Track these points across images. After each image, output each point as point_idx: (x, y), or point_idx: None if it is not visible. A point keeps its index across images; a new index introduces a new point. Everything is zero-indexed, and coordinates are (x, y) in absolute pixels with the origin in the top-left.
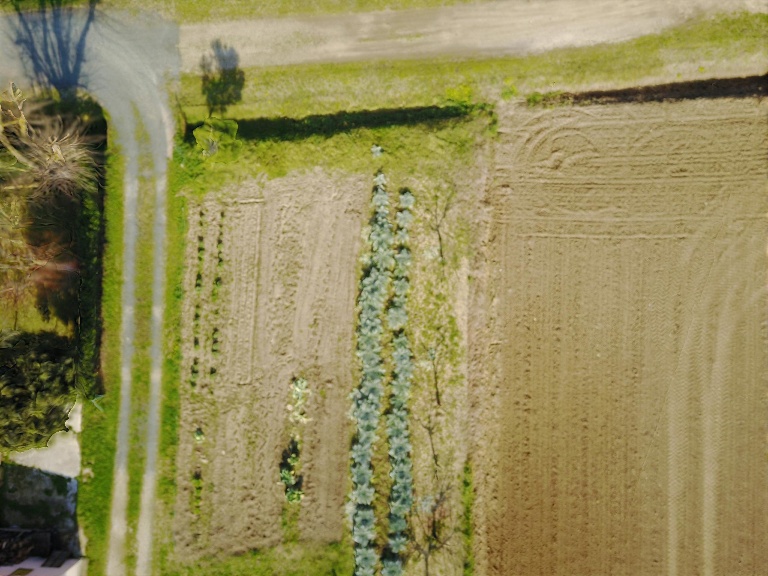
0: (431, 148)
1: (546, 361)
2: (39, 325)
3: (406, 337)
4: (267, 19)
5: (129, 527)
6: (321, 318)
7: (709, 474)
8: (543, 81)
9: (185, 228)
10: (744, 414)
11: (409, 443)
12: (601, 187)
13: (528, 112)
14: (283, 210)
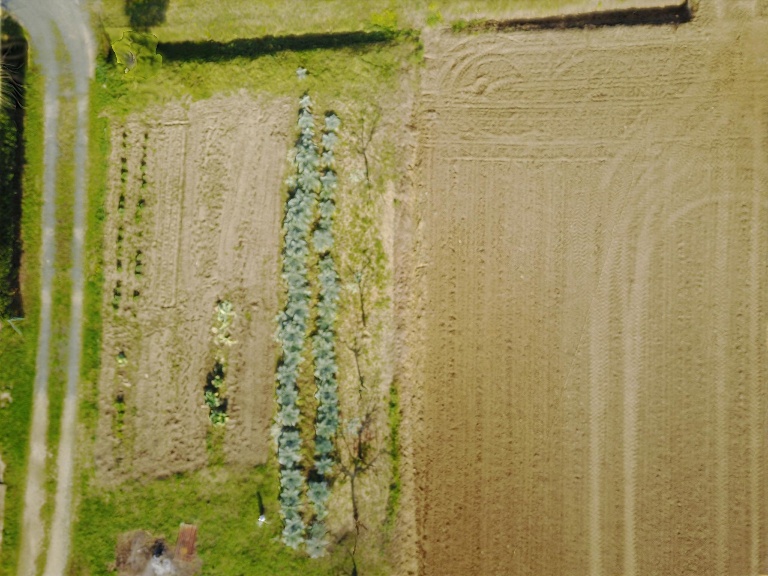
0: (357, 71)
1: (471, 283)
2: None
3: (332, 259)
4: None
5: (48, 452)
6: (246, 240)
7: (628, 391)
8: (468, 7)
9: (108, 149)
10: (661, 331)
11: (334, 364)
12: (524, 111)
13: (454, 38)
14: (208, 132)
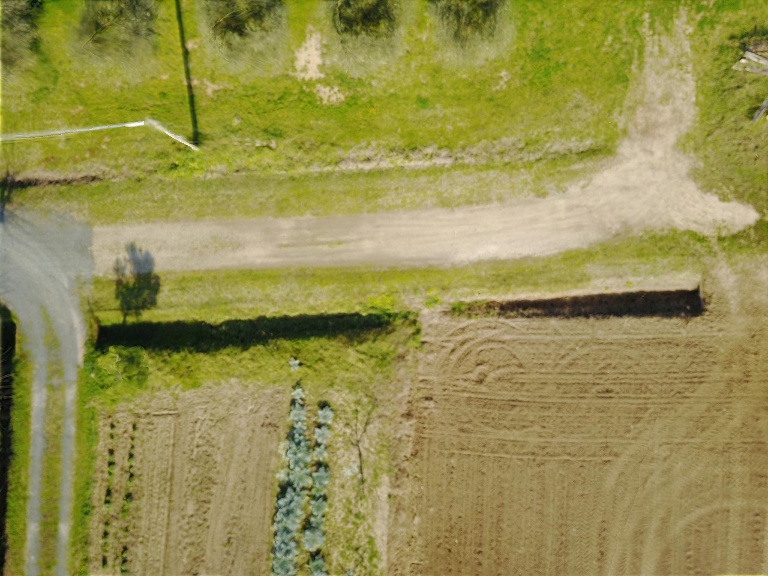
0: (351, 361)
1: None
2: None
3: (323, 559)
4: (184, 222)
5: None
6: (235, 537)
7: None
8: (468, 292)
9: (95, 441)
10: None
11: None
12: (526, 405)
13: (453, 322)
14: (197, 423)
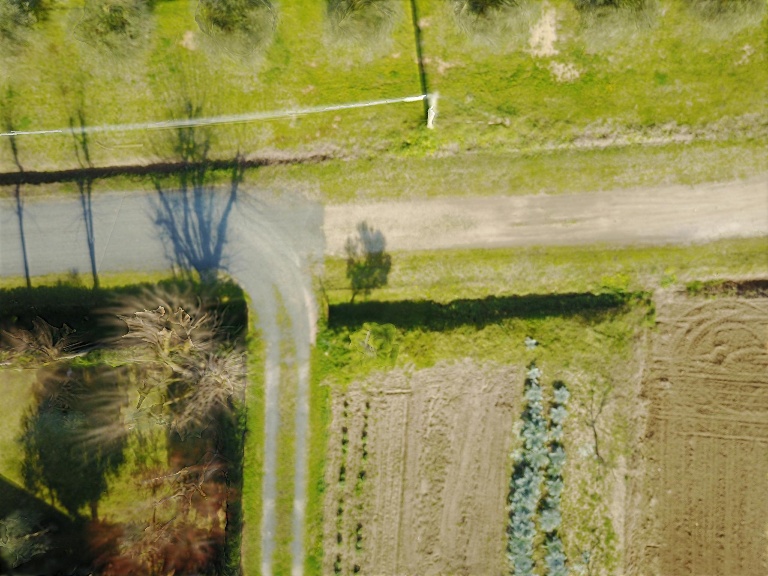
0: (588, 341)
1: (709, 569)
2: (178, 517)
3: (560, 540)
4: (415, 201)
5: None
6: (470, 516)
7: None
8: (706, 271)
9: (329, 419)
10: None
11: None
12: None
13: (689, 302)
14: (431, 402)
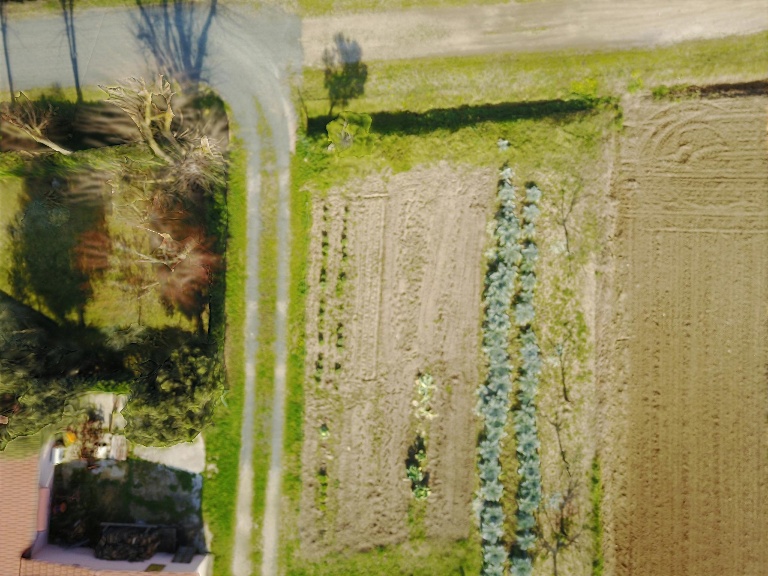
0: (558, 142)
1: (676, 357)
2: (163, 320)
3: (533, 333)
4: (390, 12)
5: (254, 523)
6: (446, 313)
7: None
8: (671, 74)
9: (309, 223)
10: None
11: (537, 439)
12: (731, 181)
13: (654, 105)
14: (407, 205)
